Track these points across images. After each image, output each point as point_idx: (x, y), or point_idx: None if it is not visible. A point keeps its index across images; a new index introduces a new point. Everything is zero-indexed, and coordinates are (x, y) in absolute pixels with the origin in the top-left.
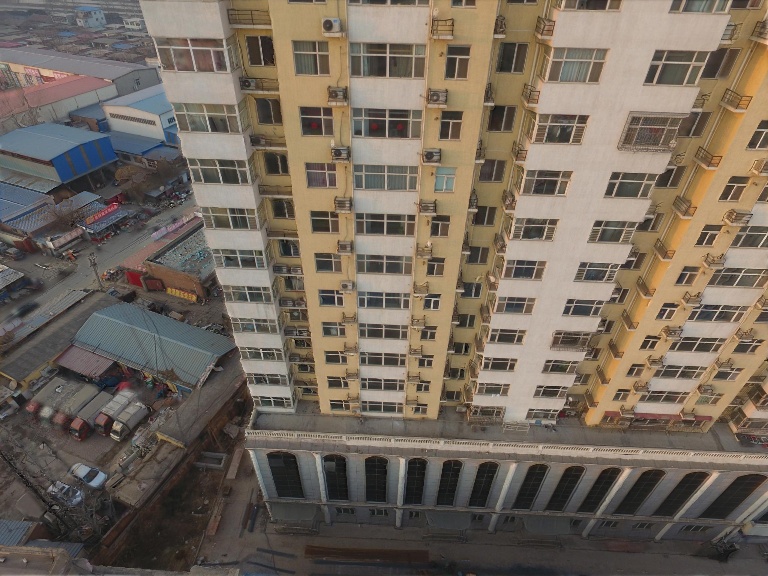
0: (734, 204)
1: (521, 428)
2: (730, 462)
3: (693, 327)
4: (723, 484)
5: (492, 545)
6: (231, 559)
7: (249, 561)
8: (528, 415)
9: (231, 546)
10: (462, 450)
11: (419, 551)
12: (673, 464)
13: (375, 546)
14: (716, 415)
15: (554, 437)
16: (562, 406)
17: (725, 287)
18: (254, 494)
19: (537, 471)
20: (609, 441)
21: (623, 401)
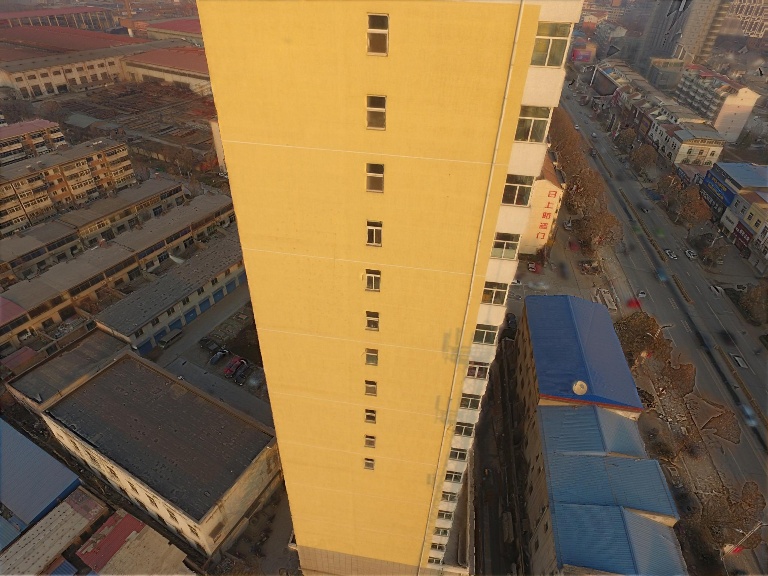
0: None
1: None
2: None
3: None
4: None
5: None
6: None
7: None
8: None
9: None
10: None
11: None
12: None
13: None
14: None
15: None
16: None
17: None
18: None
19: None
20: None
21: None
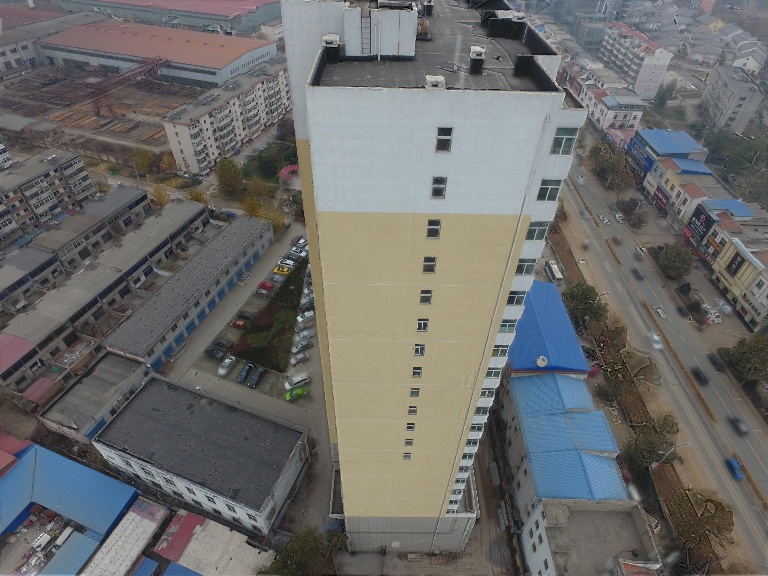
0: None
1: None
2: None
3: None
4: None
5: None
6: (491, 572)
7: (490, 558)
8: None
9: (484, 575)
10: None
11: None
12: None
13: None
14: None
15: None
16: None
17: None
18: (449, 569)
19: None
20: None
21: None
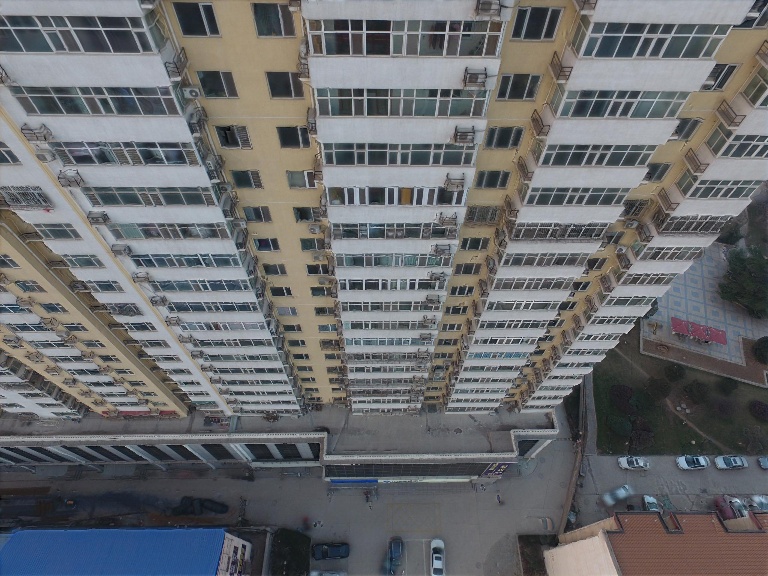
0: (2, 333)
1: (46, 424)
2: (187, 438)
3: (83, 378)
4: (200, 447)
5: (97, 480)
6: None
7: None
8: (56, 414)
9: None
10: (5, 441)
11: (44, 487)
12: (148, 442)
13: (14, 486)
14: (178, 410)
15: (77, 427)
16: (70, 410)
17: (69, 363)
18: None
19: (72, 447)
20: (114, 428)
21: (105, 407)
